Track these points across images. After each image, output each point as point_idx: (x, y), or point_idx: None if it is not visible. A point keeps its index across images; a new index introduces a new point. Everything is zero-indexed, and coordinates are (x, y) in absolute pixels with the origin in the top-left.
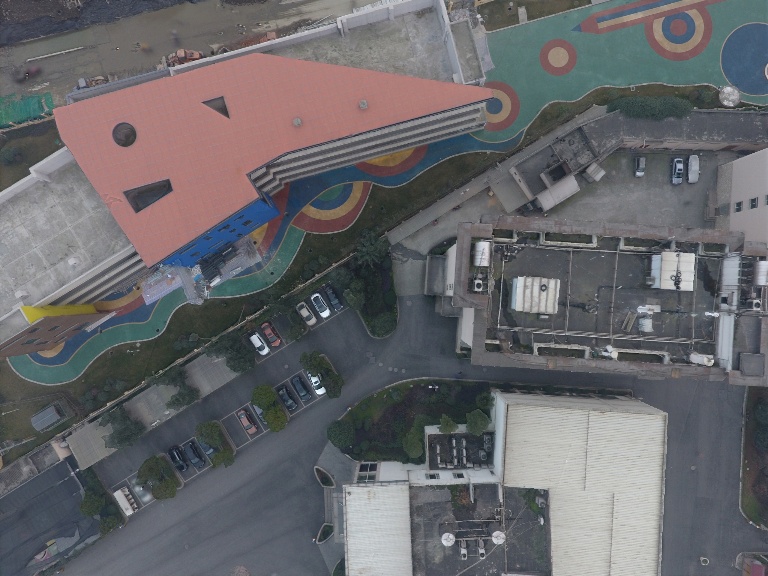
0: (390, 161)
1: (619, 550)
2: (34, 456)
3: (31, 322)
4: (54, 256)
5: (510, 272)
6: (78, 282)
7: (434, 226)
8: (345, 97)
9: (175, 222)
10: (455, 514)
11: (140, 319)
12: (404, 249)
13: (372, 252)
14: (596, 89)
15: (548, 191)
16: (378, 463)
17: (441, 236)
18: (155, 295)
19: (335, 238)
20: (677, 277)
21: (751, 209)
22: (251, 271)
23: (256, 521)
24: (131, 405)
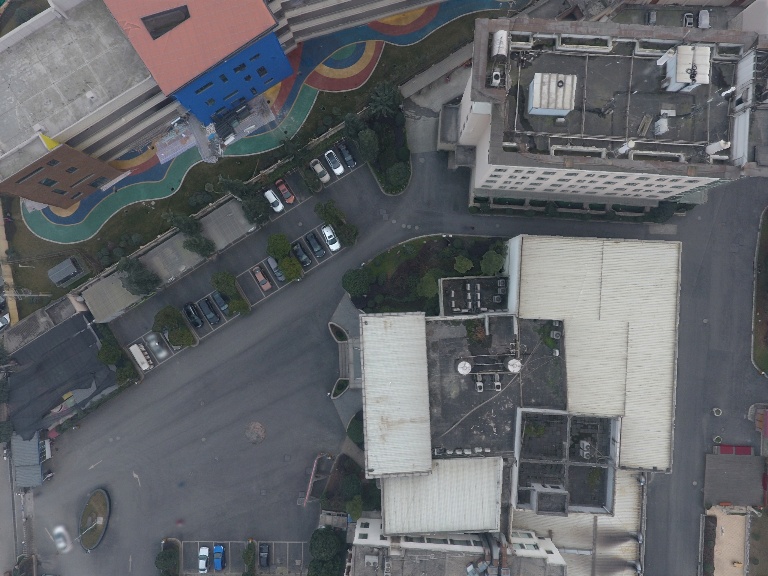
0: (402, 20)
1: (634, 378)
2: (50, 310)
3: (50, 149)
4: (72, 92)
5: (526, 79)
6: (96, 117)
7: (446, 84)
8: None
9: (192, 49)
10: (470, 350)
11: (155, 178)
12: (417, 107)
13: (386, 102)
14: None
15: None
16: None
17: (453, 94)
18: (170, 154)
19: (348, 96)
20: (693, 70)
21: None
22: (265, 130)
23: (271, 377)
24: (147, 259)
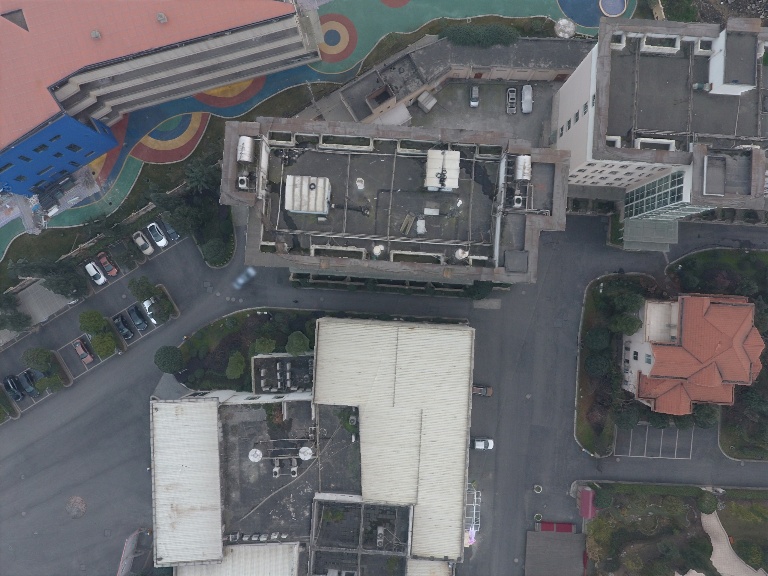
0: (229, 92)
1: (427, 466)
2: None
3: None
4: None
5: None
6: None
7: None
8: (145, 11)
9: None
10: (270, 433)
11: None
12: None
13: (201, 178)
14: (433, 21)
15: (379, 119)
16: (212, 391)
17: None
18: None
19: (172, 168)
20: (442, 174)
21: (567, 131)
22: (89, 201)
23: (92, 451)
24: None
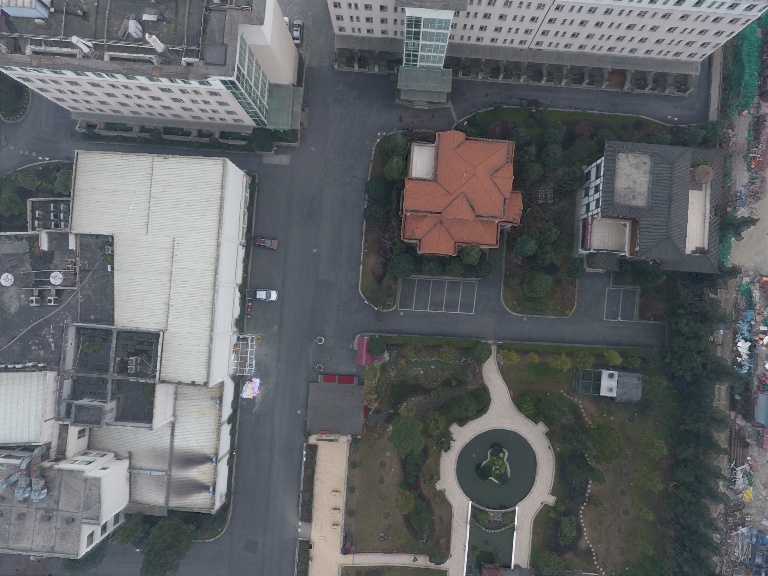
0: None
1: (177, 293)
2: None
3: None
4: None
5: None
6: None
7: None
8: None
9: None
10: (32, 265)
11: None
12: None
13: None
14: None
15: None
16: None
17: None
18: None
19: None
20: None
21: None
22: None
23: None
24: None
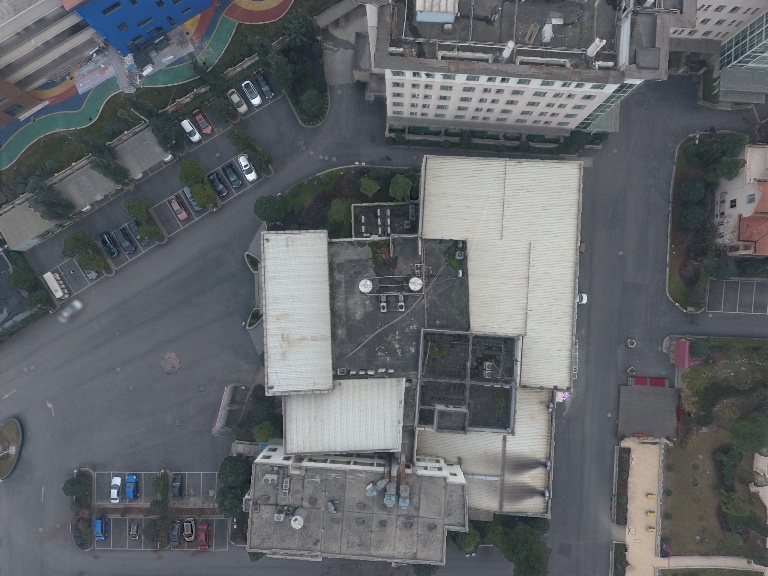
0: None
1: (535, 297)
2: None
3: None
4: None
5: None
6: (0, 34)
7: (365, 16)
8: None
9: None
10: (376, 271)
11: (73, 108)
12: (335, 39)
13: (300, 30)
14: None
15: None
16: None
17: None
18: (88, 84)
19: (266, 27)
20: None
21: None
22: (183, 61)
23: (187, 308)
24: (61, 186)
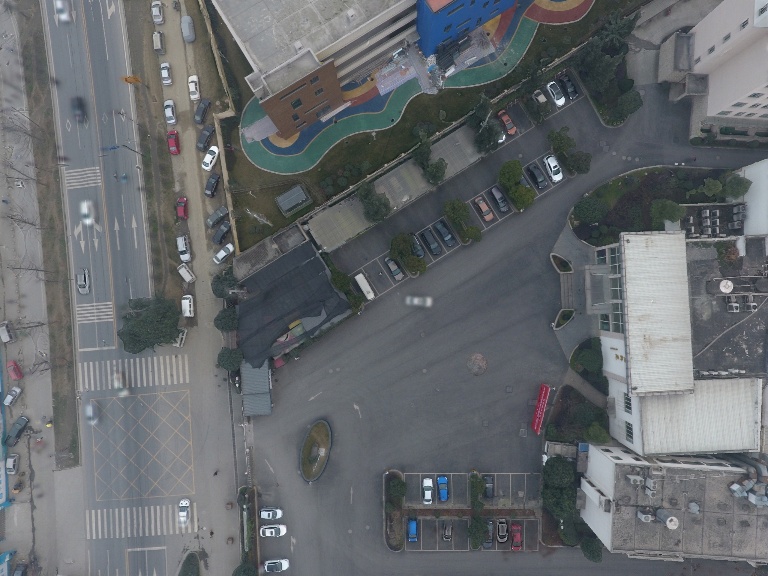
0: None
1: None
2: (277, 238)
3: (321, 63)
4: (329, 11)
5: None
6: (354, 36)
7: (666, 17)
8: None
9: None
10: (721, 272)
11: (375, 109)
12: (636, 39)
13: (618, 31)
14: None
15: None
16: None
17: (673, 26)
18: (389, 86)
19: (569, 28)
20: None
21: None
22: (485, 62)
23: (492, 309)
24: None
